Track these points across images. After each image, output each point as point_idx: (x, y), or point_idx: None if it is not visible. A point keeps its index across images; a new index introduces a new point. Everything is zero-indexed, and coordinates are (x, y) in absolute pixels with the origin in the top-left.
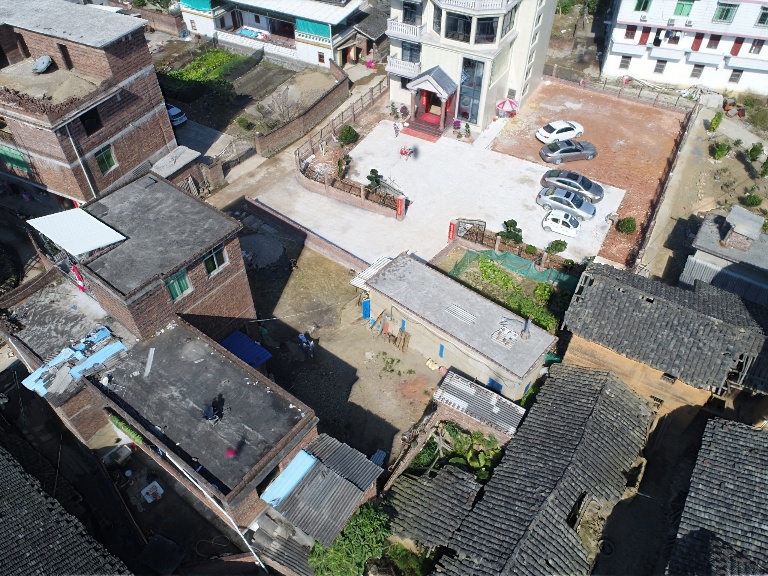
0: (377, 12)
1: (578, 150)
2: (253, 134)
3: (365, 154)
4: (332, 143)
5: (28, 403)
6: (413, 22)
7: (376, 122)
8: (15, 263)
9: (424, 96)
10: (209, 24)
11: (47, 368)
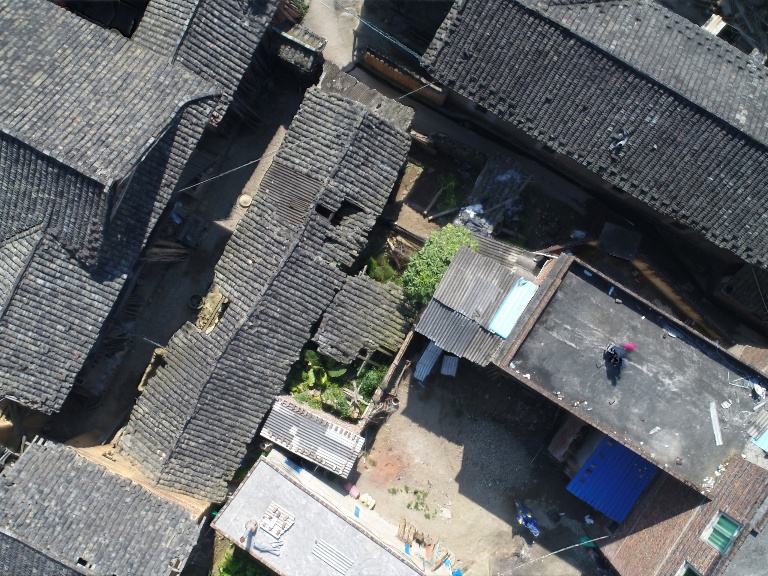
0: None
1: None
2: None
3: None
4: None
5: None
6: None
7: None
8: None
9: None
10: None
11: None
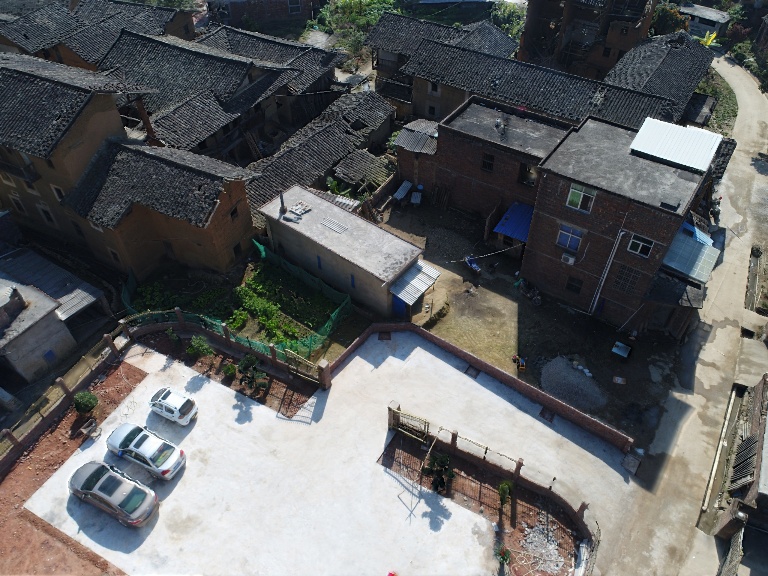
0: None
1: None
2: None
3: None
4: None
5: None
6: None
7: None
8: None
9: None
10: None
11: None
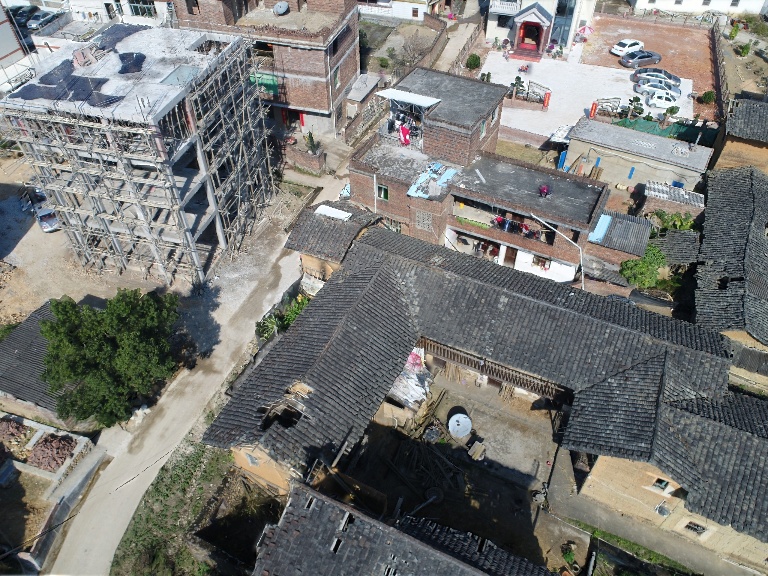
0: None
1: (649, 56)
2: None
3: (492, 74)
4: (461, 69)
5: None
6: None
7: (485, 53)
8: None
9: (522, 29)
10: None
11: (418, 184)
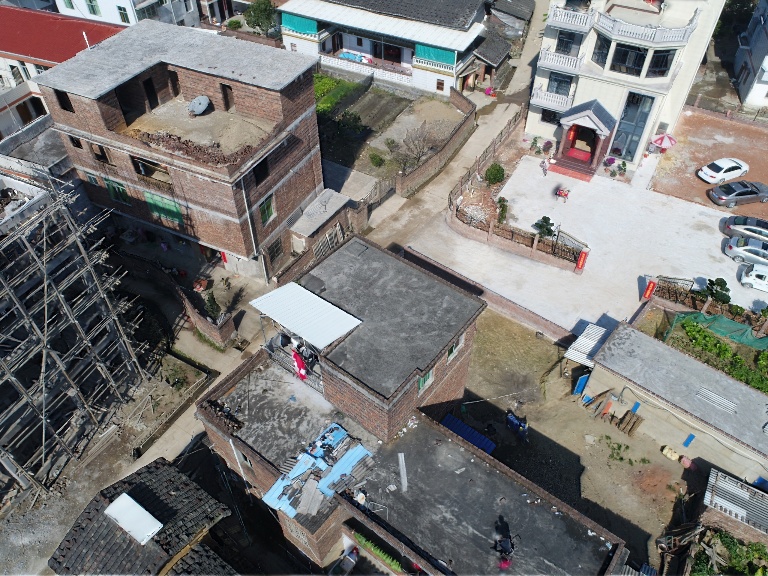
0: (492, 35)
1: (754, 192)
2: None
3: (517, 195)
4: (476, 182)
5: (215, 497)
6: (564, 52)
7: (517, 158)
8: (160, 322)
9: (572, 131)
10: (312, 48)
11: (288, 481)
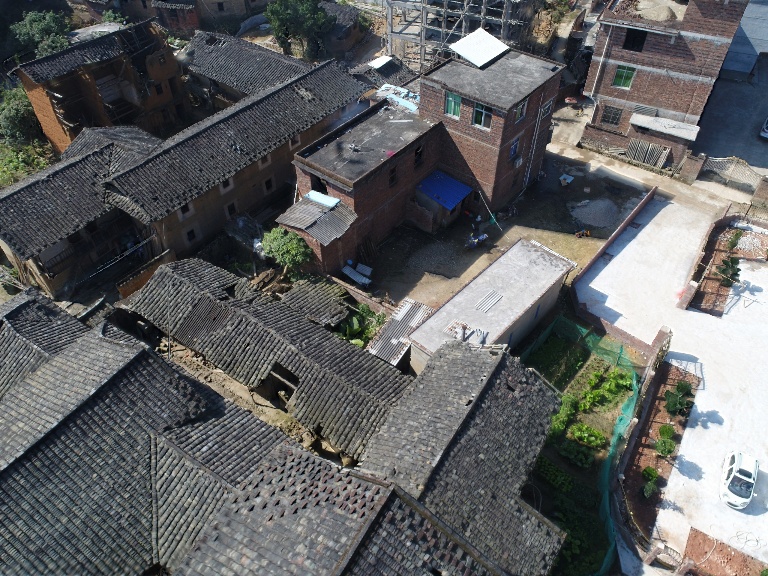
0: None
1: None
2: (765, 175)
3: None
4: None
5: None
6: None
7: None
8: None
9: None
10: None
11: None
